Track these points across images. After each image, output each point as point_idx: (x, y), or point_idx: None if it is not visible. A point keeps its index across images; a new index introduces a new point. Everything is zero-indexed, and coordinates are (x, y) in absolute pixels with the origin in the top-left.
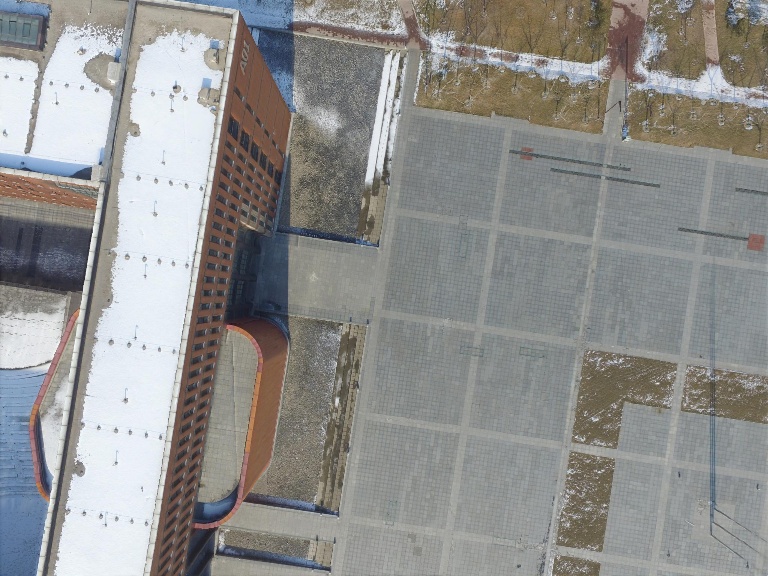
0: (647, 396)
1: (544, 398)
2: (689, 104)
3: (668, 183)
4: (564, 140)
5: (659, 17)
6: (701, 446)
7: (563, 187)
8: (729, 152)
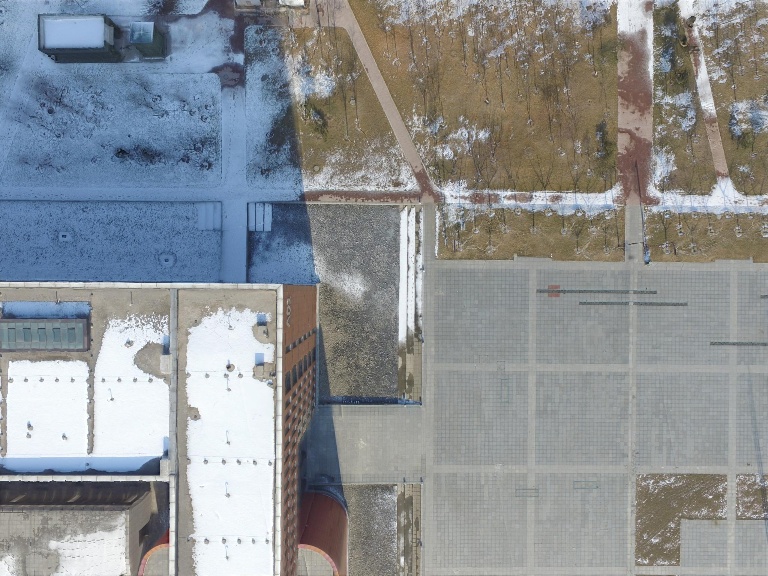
0: (702, 510)
1: (603, 527)
2: (705, 220)
3: (695, 300)
4: (588, 272)
5: (665, 138)
6: (760, 551)
7: (594, 319)
8: (750, 261)
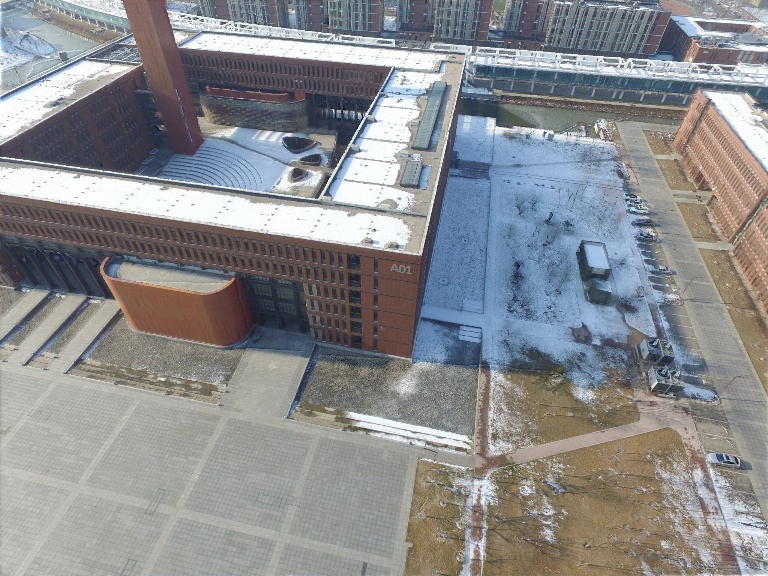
0: None
1: None
2: None
3: None
4: None
5: None
6: None
7: None
8: None
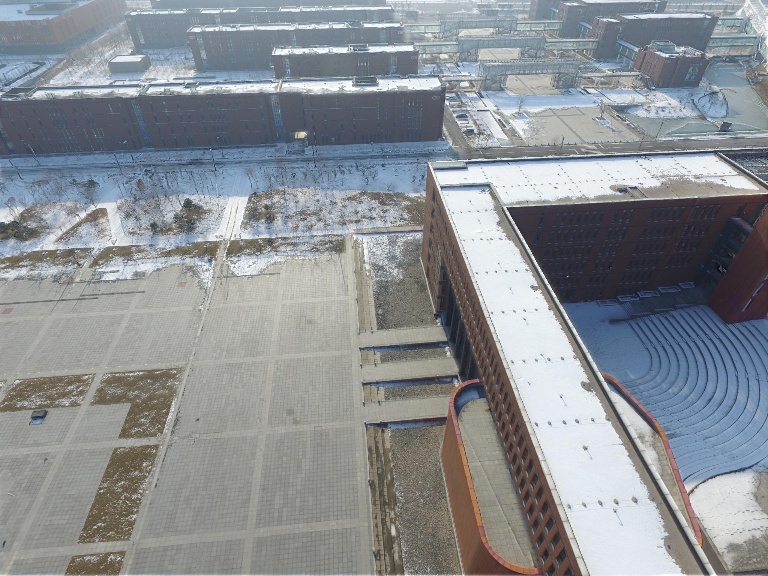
0: None
1: None
2: None
3: None
4: None
5: None
6: None
7: None
8: None
